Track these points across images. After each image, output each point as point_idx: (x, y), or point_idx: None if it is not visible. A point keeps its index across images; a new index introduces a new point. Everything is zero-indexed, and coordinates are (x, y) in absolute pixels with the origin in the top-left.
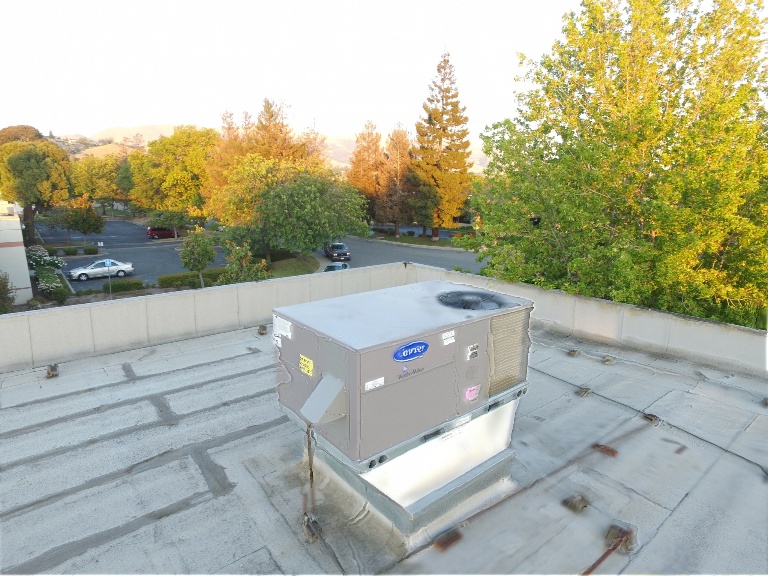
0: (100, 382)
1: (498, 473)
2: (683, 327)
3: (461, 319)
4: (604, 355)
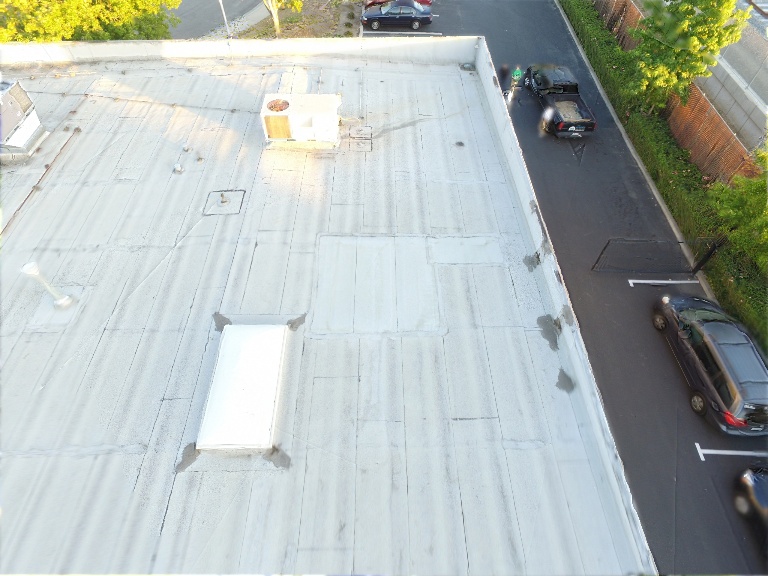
0: None
1: (42, 131)
2: (93, 47)
3: (1, 96)
4: (69, 73)
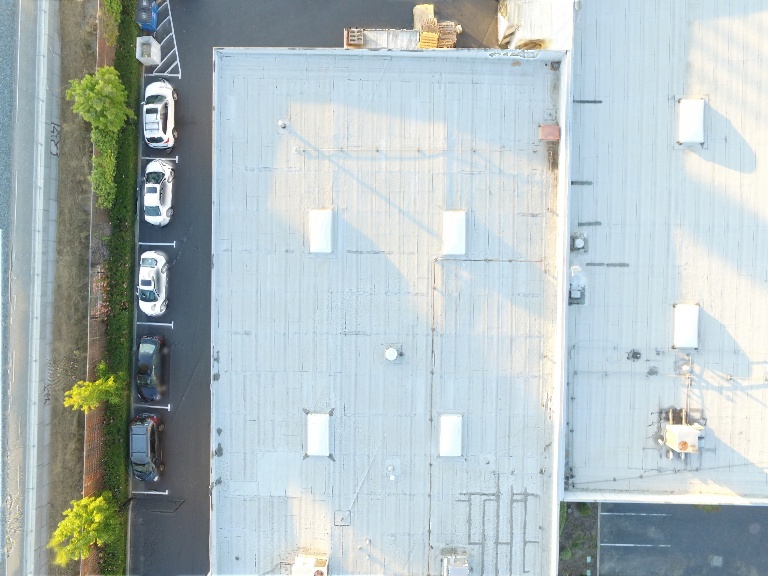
0: (528, 536)
1: None
2: None
3: None
4: None
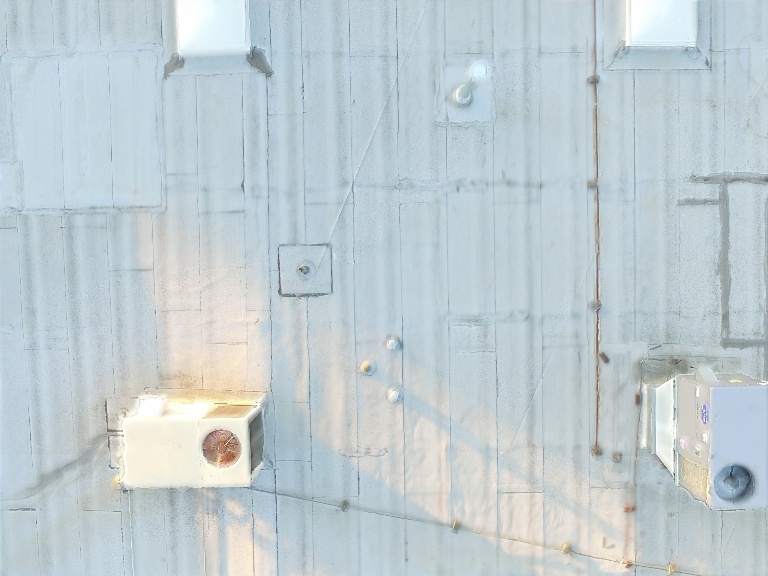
0: None
1: None
2: None
3: (711, 450)
4: None
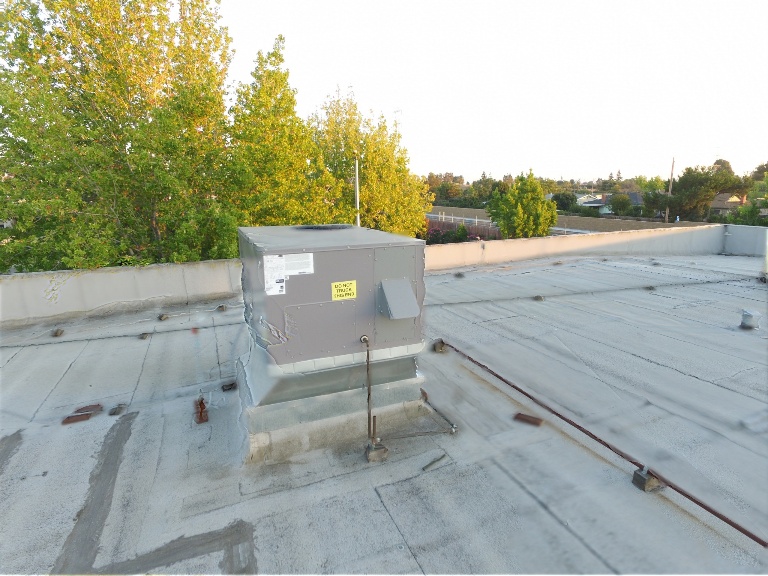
0: None
1: None
2: None
3: None
4: None
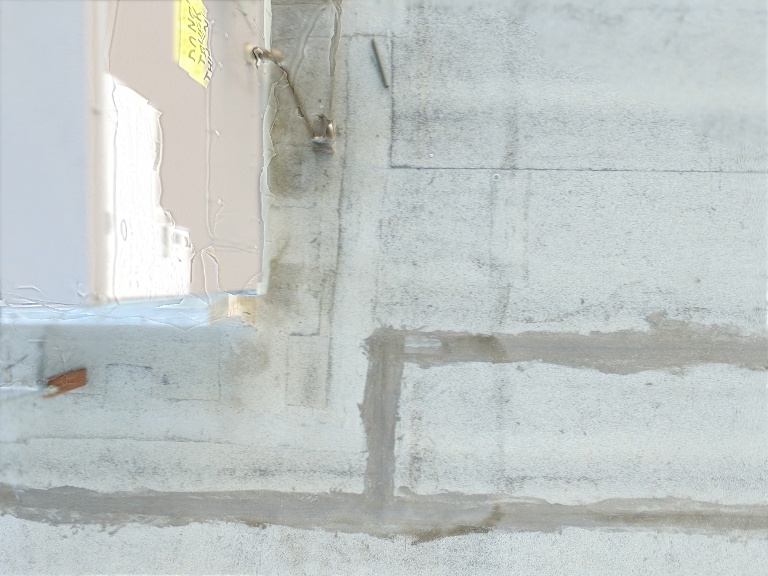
0: None
1: None
2: None
3: None
4: None
